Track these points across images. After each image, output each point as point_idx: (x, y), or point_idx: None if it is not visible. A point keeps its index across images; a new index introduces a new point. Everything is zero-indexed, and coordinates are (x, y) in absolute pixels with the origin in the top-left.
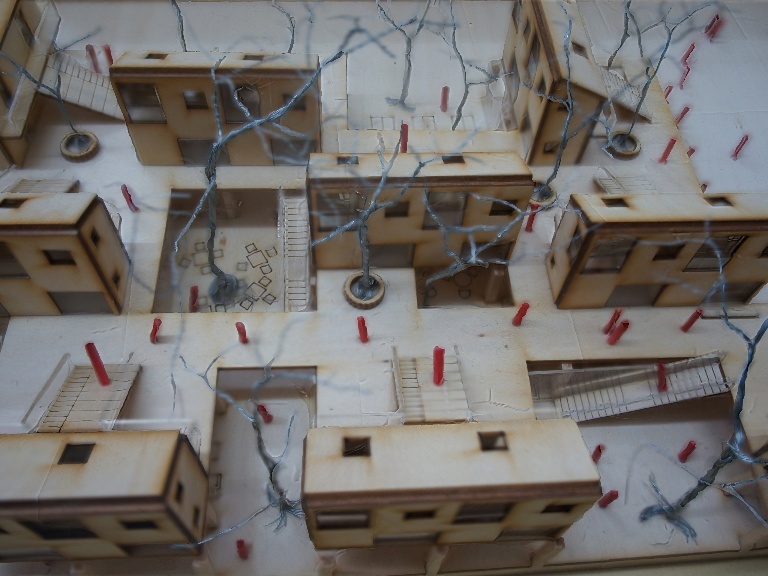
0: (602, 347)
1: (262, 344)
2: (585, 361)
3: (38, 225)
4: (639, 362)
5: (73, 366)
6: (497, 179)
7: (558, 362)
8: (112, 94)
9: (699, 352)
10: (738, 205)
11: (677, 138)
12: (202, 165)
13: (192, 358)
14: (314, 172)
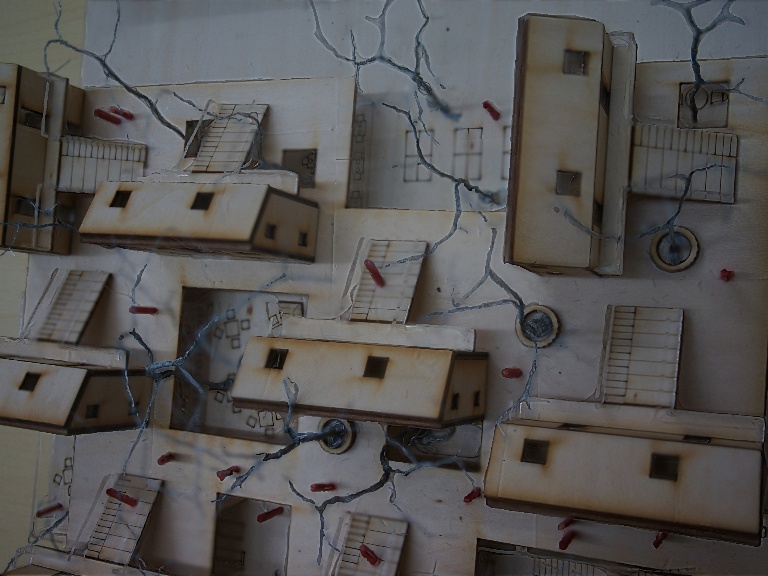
0: (560, 538)
1: (250, 476)
2: (538, 550)
3: (41, 423)
4: (597, 562)
5: (116, 478)
6: (402, 418)
7: (509, 545)
8: (126, 166)
9: (670, 565)
10: (684, 479)
11: (766, 232)
12: (206, 258)
13: (199, 480)
14: (238, 383)
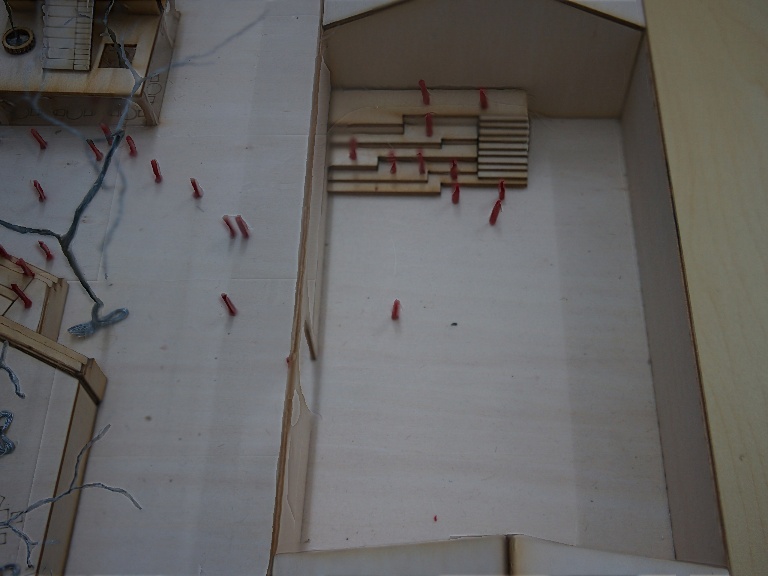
0: None
1: None
2: None
3: None
4: None
5: None
6: None
7: None
8: None
9: None
10: None
11: (19, 86)
12: None
13: None
14: None
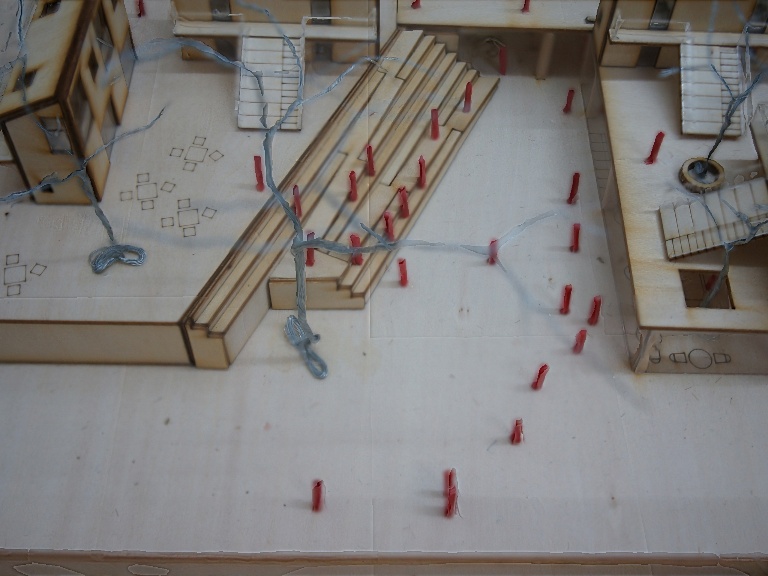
0: None
1: None
2: None
3: None
4: None
5: None
6: None
7: None
8: None
9: None
10: None
11: (625, 190)
12: None
13: None
14: None
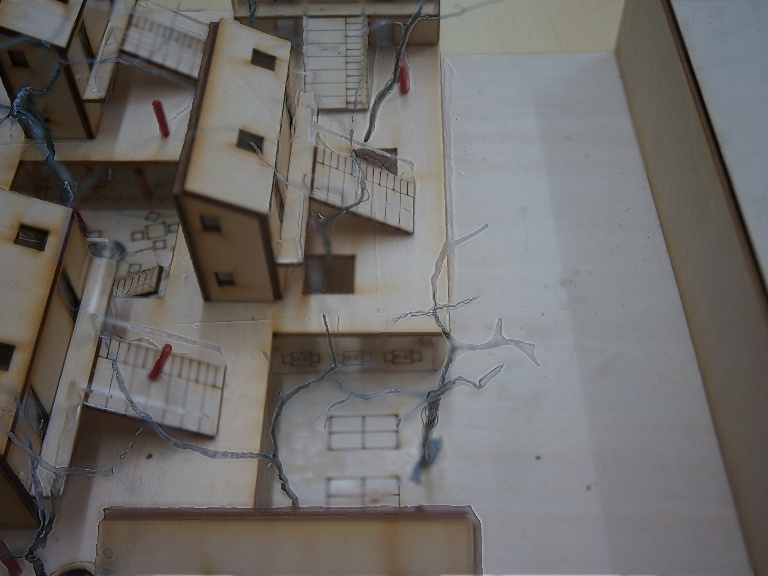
0: None
1: None
2: None
3: None
4: None
5: None
6: None
7: None
8: (340, 88)
9: None
10: None
11: None
12: None
13: None
14: (3, 194)
